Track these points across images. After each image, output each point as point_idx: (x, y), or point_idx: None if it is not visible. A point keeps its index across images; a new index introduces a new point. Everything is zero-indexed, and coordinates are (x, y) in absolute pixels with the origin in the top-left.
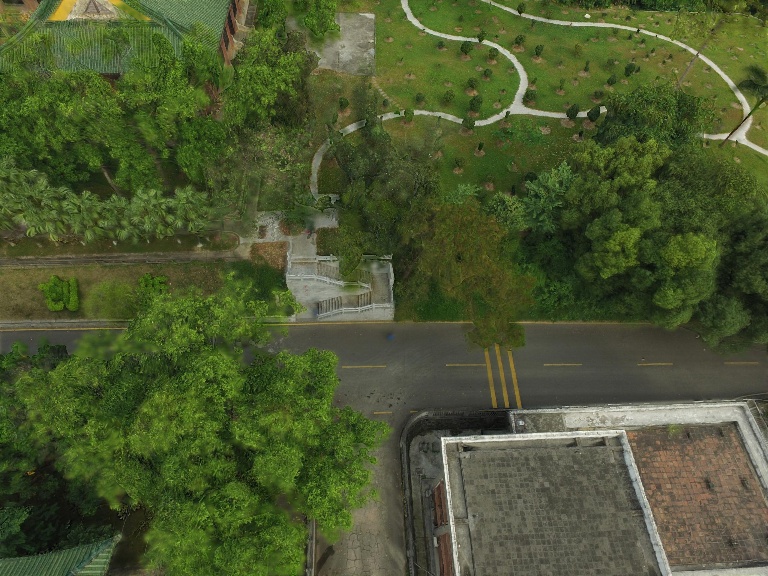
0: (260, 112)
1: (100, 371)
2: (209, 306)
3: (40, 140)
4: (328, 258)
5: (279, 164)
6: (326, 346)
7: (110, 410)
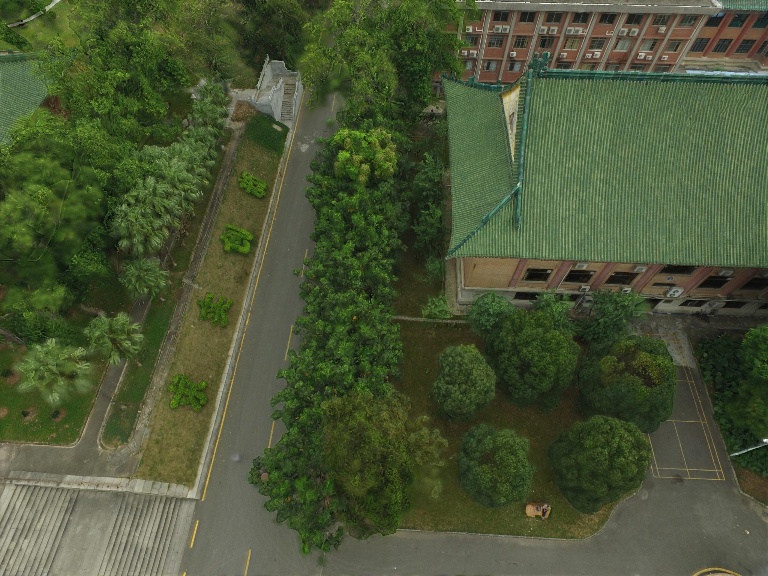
0: (173, 0)
1: (361, 57)
2: (338, 2)
3: (128, 125)
4: (259, 83)
5: (223, 4)
6: (315, 118)
7: (388, 38)
